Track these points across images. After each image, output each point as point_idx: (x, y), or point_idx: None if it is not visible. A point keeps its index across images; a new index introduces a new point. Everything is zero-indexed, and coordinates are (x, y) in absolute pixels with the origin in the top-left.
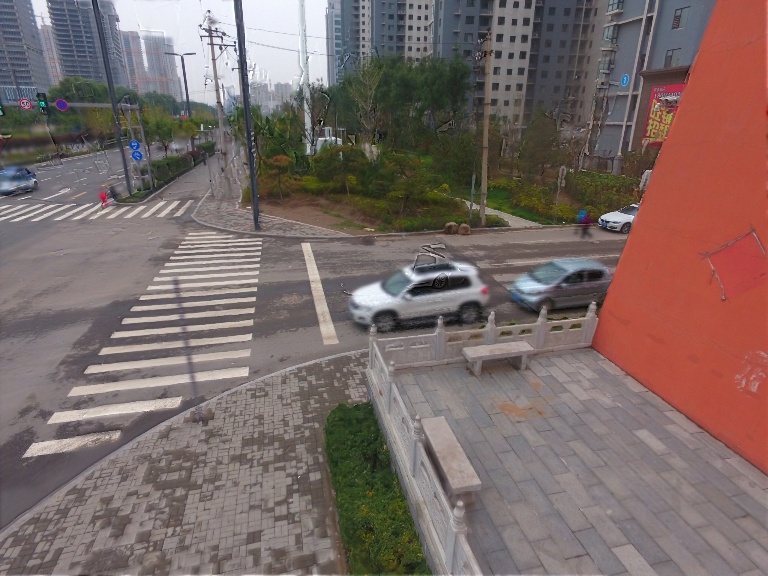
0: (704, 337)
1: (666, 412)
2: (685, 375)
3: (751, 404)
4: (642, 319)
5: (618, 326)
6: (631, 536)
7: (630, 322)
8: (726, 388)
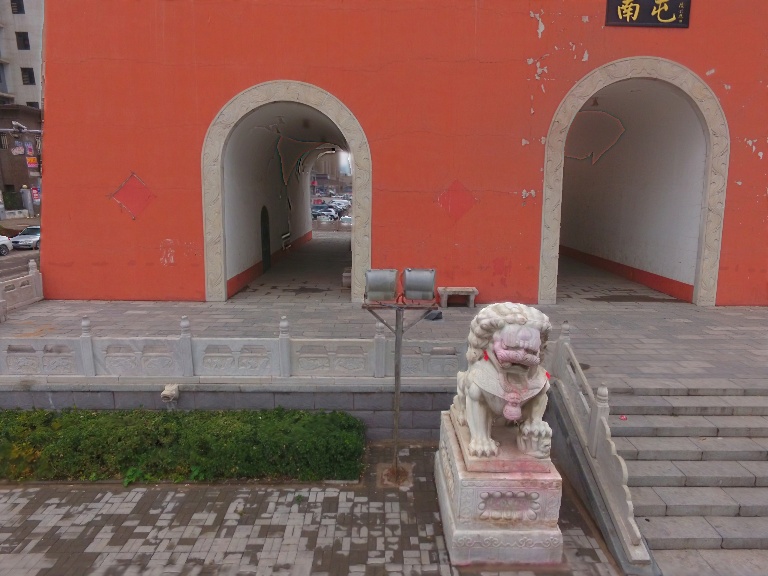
0: (132, 246)
1: (131, 303)
2: (131, 276)
3: (174, 270)
4: (82, 256)
5: (63, 270)
6: (166, 334)
7: (73, 262)
8: (158, 269)
